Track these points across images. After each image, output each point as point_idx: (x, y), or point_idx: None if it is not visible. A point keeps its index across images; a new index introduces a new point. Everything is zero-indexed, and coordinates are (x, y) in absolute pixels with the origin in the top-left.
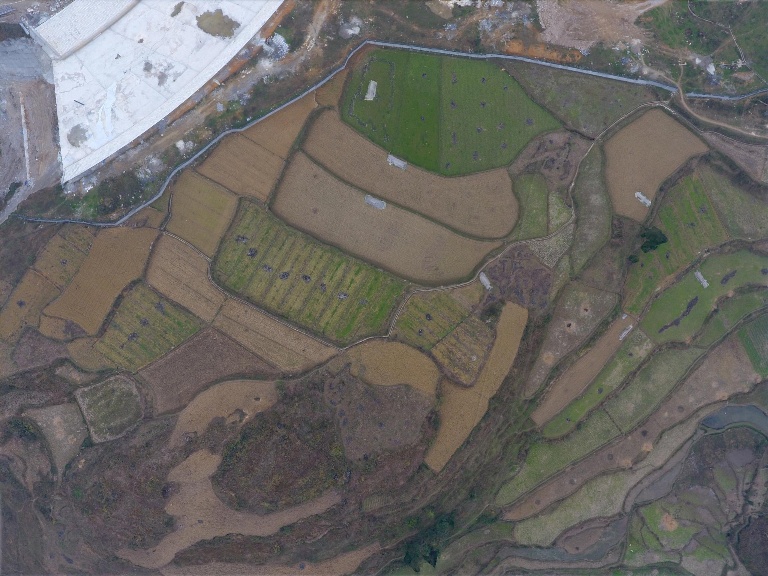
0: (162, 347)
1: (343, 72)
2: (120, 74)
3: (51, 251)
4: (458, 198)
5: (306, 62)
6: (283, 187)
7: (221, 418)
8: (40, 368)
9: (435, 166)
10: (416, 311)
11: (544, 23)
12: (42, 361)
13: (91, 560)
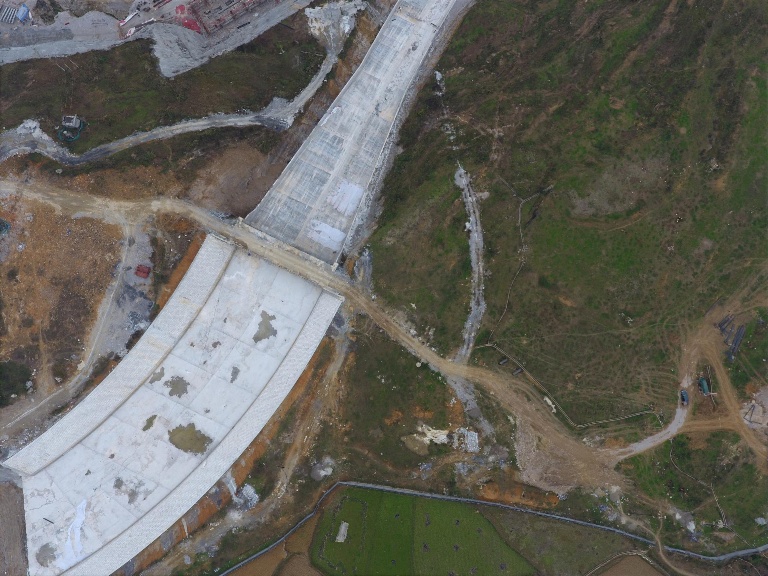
0: None
1: (314, 517)
2: (90, 491)
3: None
4: None
5: (276, 511)
6: None
7: None
8: None
9: None
10: None
11: (522, 465)
12: None
13: None
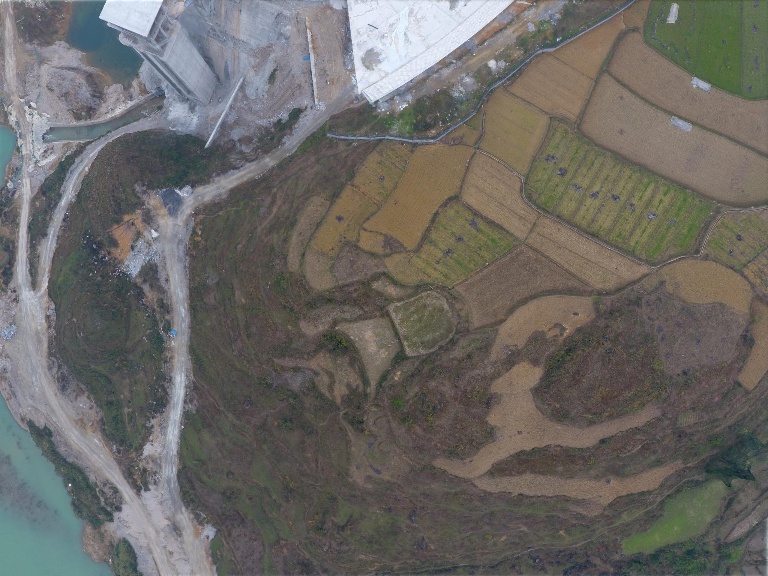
0: (477, 263)
1: None
2: None
3: (369, 167)
4: (763, 121)
5: None
6: (590, 108)
7: (541, 332)
8: (359, 282)
9: (738, 89)
10: (727, 231)
11: None
12: (361, 275)
13: (402, 470)
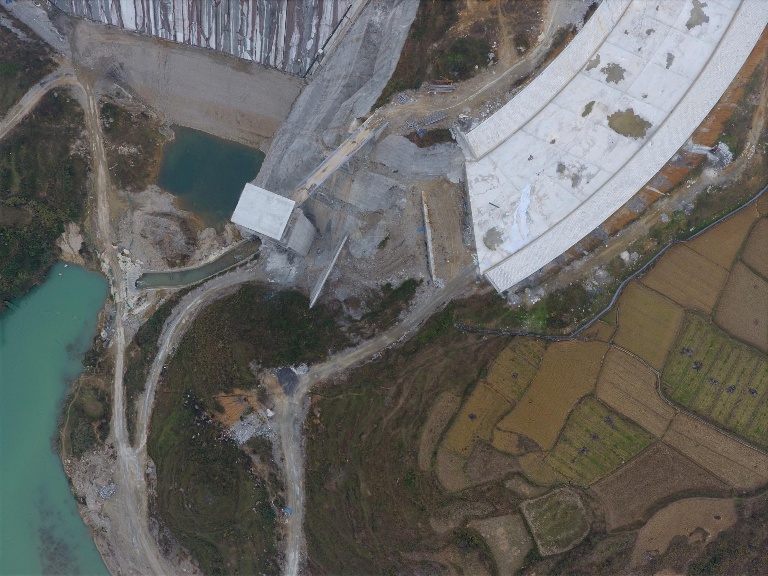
0: (613, 462)
1: None
2: (533, 176)
3: (502, 364)
4: None
5: (748, 170)
6: (723, 298)
7: (682, 537)
8: (493, 482)
9: None
10: None
11: None
12: (494, 475)
13: None
